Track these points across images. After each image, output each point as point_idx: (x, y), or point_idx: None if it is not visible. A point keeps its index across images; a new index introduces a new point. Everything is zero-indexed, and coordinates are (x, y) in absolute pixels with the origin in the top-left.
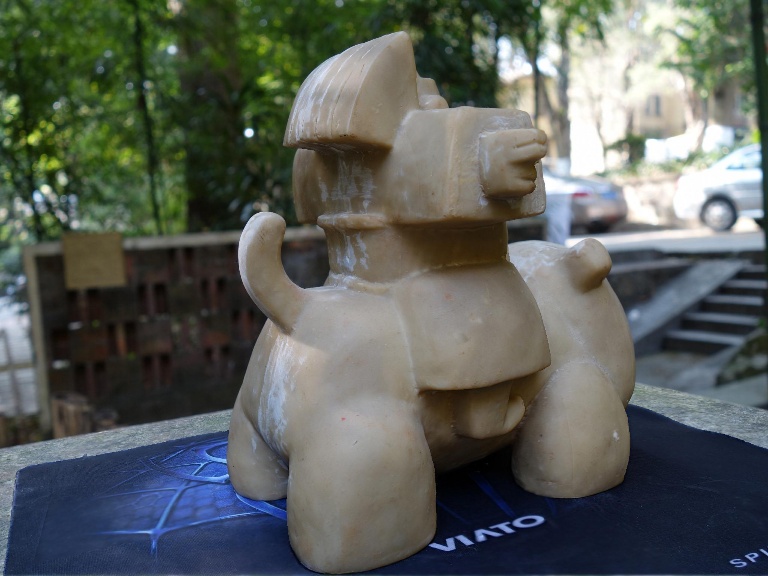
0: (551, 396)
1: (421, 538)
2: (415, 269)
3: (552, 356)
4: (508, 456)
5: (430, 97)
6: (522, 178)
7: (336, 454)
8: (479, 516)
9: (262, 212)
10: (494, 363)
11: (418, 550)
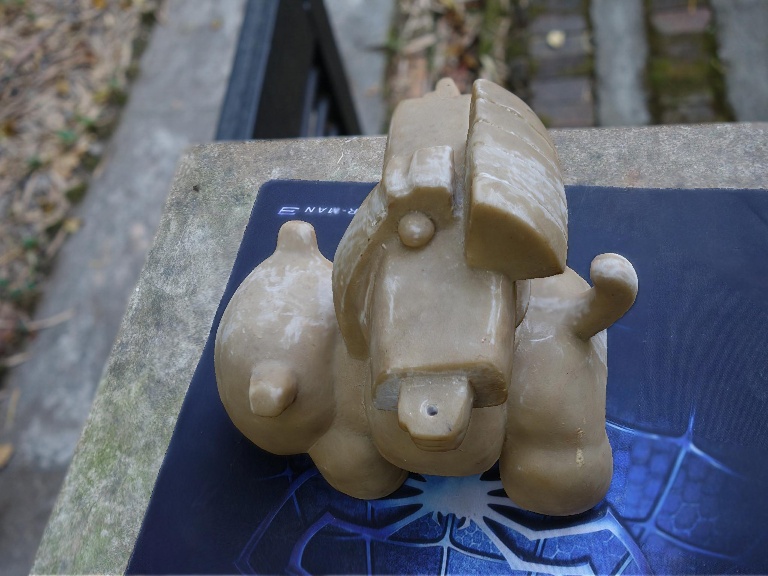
0: None
1: None
2: None
3: None
4: None
5: None
6: None
7: None
8: None
9: (616, 259)
10: None
11: None
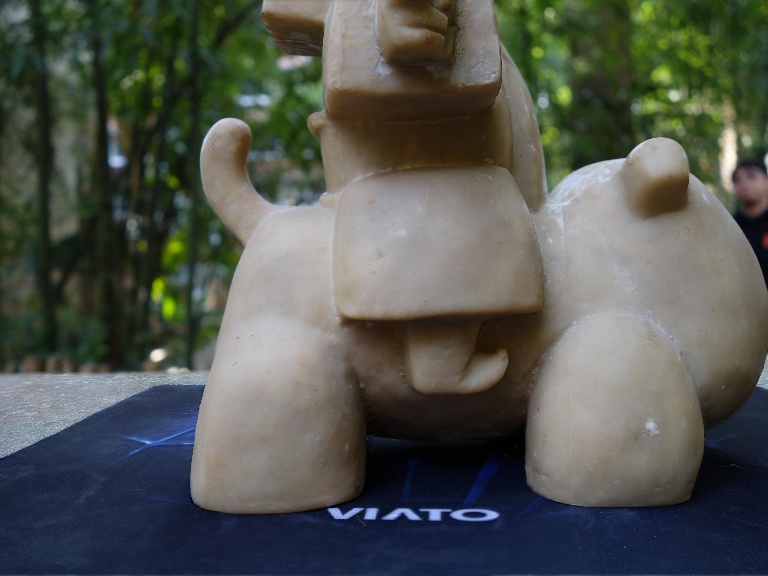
0: (556, 356)
1: (309, 495)
2: (358, 173)
3: (568, 302)
4: (524, 437)
5: None
6: (409, 25)
7: (217, 374)
8: (429, 496)
9: None
10: (416, 289)
11: (306, 509)
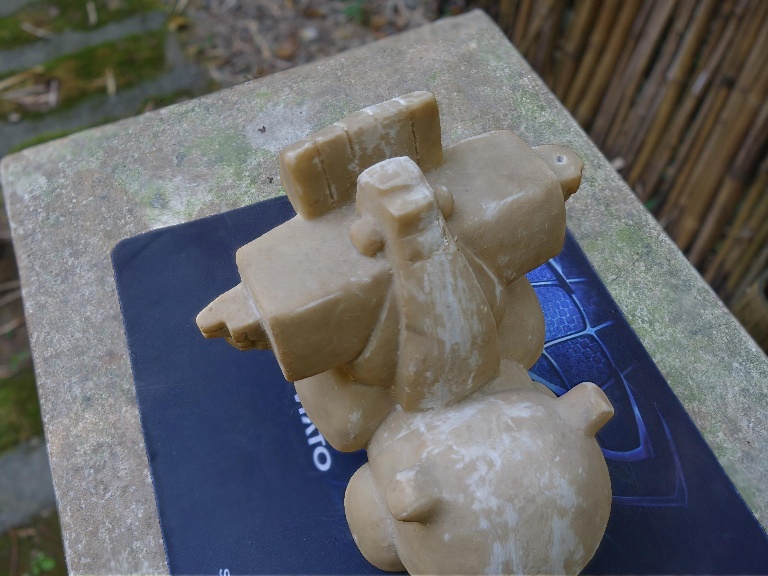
0: (361, 468)
1: None
2: None
3: (371, 464)
4: None
5: (355, 223)
6: None
7: None
8: None
9: None
10: None
11: None
